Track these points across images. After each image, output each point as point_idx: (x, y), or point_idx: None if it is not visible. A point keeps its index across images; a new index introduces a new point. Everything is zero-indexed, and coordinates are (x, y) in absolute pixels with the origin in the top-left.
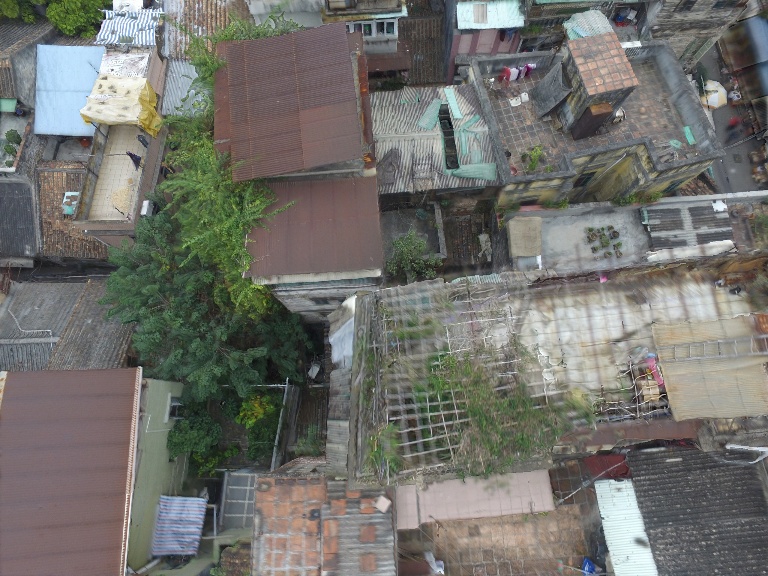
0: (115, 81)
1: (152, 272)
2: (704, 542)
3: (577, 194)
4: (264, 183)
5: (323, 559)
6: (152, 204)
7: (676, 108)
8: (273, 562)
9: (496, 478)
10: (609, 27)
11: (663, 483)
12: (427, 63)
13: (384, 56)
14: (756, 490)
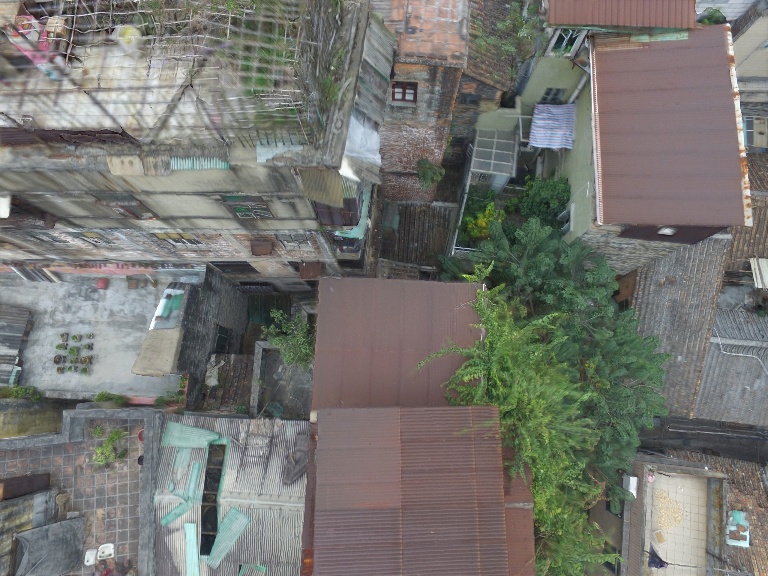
0: None
1: None
2: None
3: None
4: None
5: None
6: None
7: None
8: (451, 2)
9: None
10: None
11: None
12: None
13: None
14: None
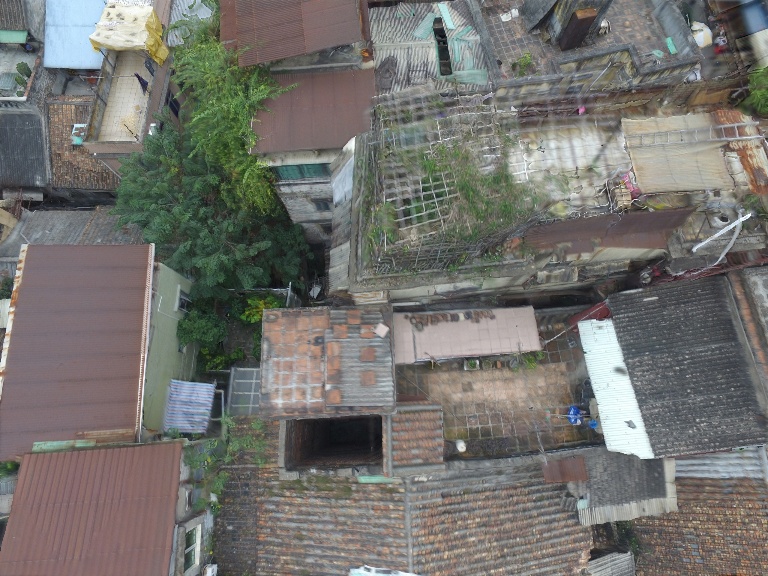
0: (123, 9)
1: (161, 176)
2: (678, 367)
3: None
4: (268, 74)
5: (327, 374)
6: None
7: (659, 21)
8: (281, 381)
9: (487, 322)
10: None
11: (640, 319)
12: None
13: None
14: (725, 320)
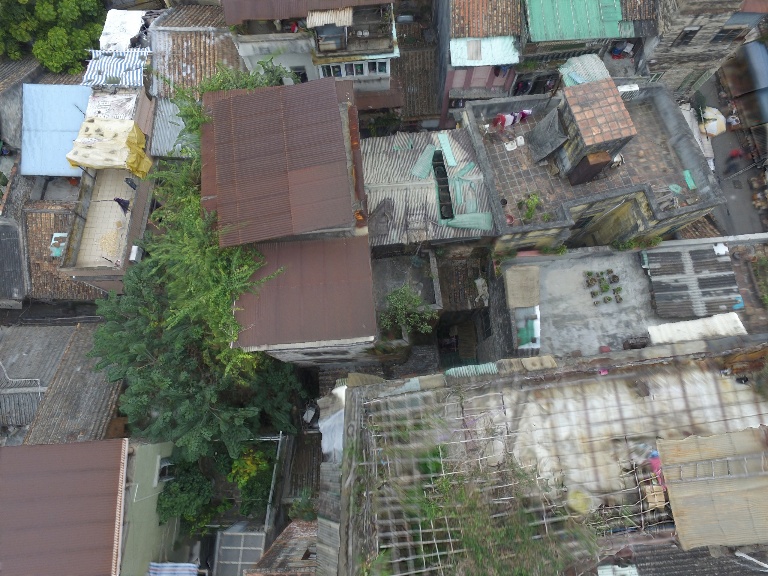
0: (102, 124)
1: (140, 328)
2: None
3: (575, 235)
4: (252, 244)
5: None
6: (141, 248)
7: (675, 151)
8: None
9: None
10: (606, 72)
11: (669, 570)
12: (421, 95)
13: (377, 93)
14: None
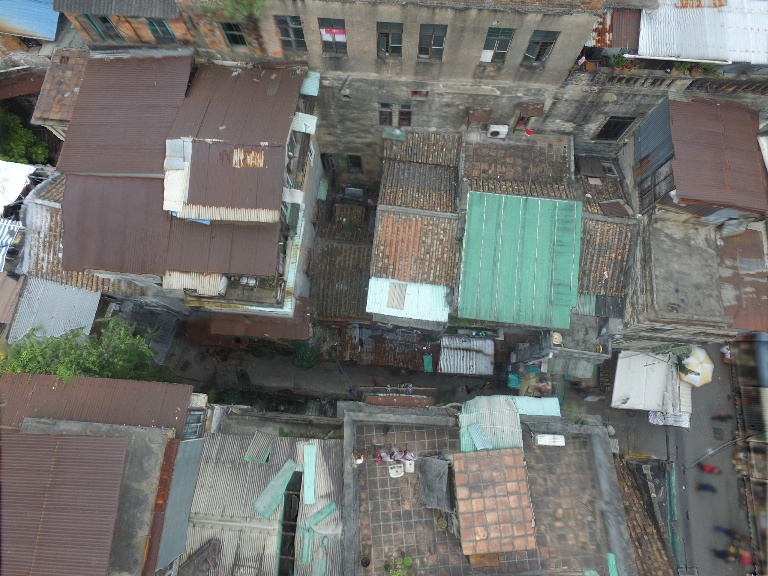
0: None
1: None
2: None
3: None
4: None
5: None
6: None
7: (604, 520)
8: None
9: None
10: (518, 433)
11: None
12: (350, 295)
13: (277, 320)
14: None
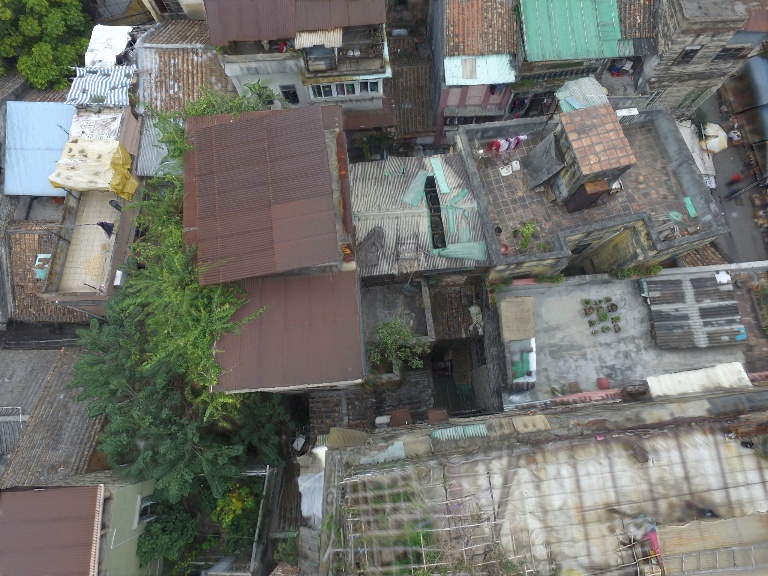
0: (86, 144)
1: (121, 361)
2: None
3: (573, 260)
4: None
5: None
6: None
7: (676, 177)
8: None
9: None
10: (604, 97)
11: None
12: (415, 112)
13: (369, 112)
14: None
